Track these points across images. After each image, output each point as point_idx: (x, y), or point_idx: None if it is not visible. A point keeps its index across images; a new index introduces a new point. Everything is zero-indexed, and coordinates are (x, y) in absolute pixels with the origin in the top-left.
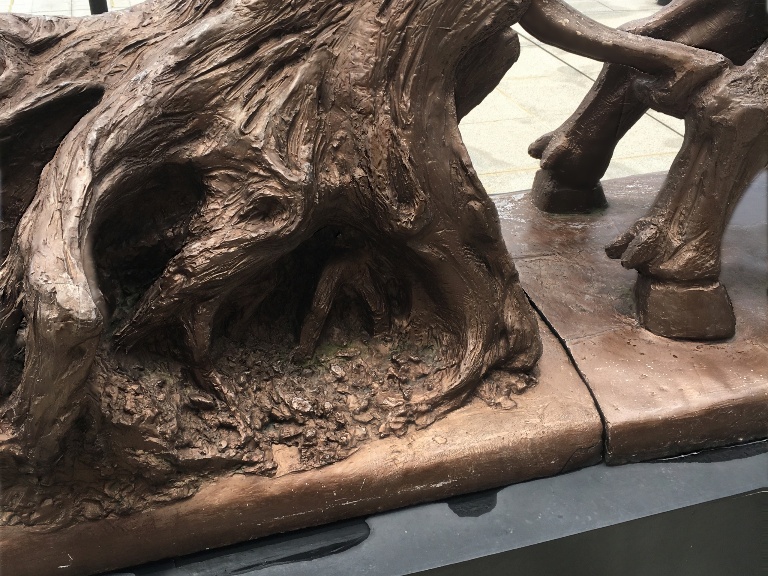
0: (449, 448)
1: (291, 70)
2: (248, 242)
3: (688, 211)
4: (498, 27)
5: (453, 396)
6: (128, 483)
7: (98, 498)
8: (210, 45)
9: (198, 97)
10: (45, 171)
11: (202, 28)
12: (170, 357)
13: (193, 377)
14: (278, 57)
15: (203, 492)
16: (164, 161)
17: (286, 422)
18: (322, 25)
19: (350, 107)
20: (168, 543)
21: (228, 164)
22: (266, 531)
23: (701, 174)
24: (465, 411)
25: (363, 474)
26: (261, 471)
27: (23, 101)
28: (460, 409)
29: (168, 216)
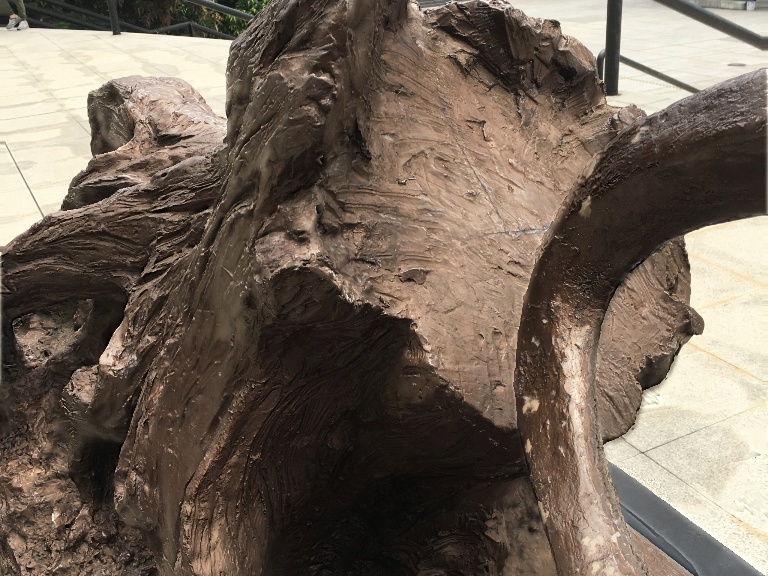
0: None
1: None
2: None
3: None
4: None
5: None
6: None
7: None
8: (175, 185)
9: (146, 233)
10: None
11: (178, 164)
12: None
13: None
14: (197, 225)
15: None
16: (108, 279)
17: None
18: None
19: None
20: None
21: None
22: None
23: None
24: None
25: None
26: None
27: None
28: None
29: None
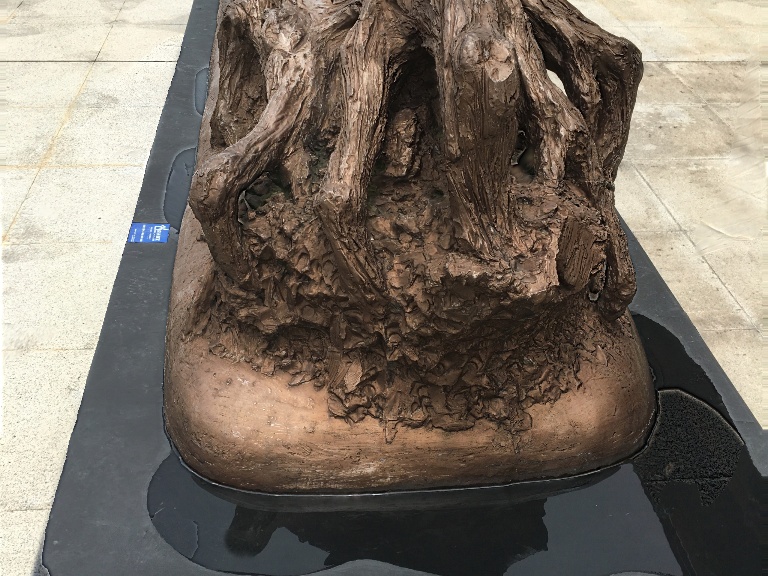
0: None
1: None
2: None
3: None
4: None
5: None
6: None
7: None
8: None
9: None
10: (542, 8)
11: None
12: None
13: None
14: None
15: None
16: None
17: None
18: None
19: None
20: None
21: None
22: None
23: None
24: None
25: None
26: None
27: None
28: None
29: None
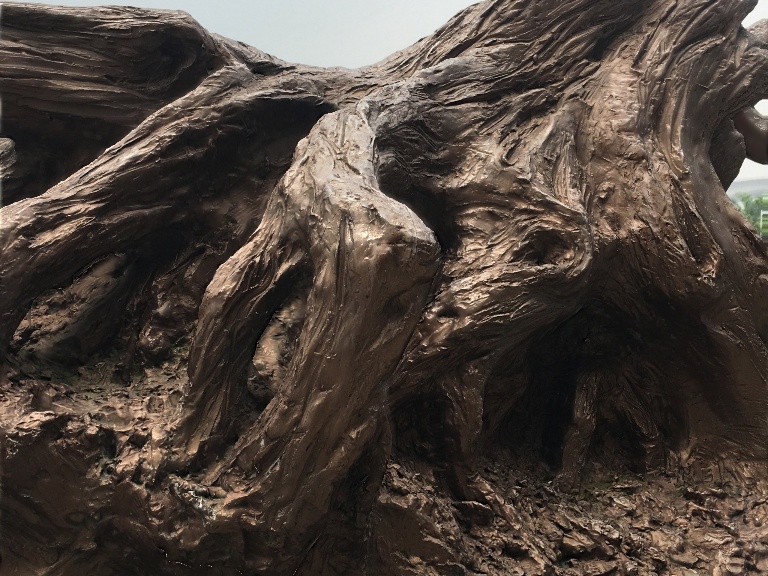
0: None
1: (541, 119)
2: (533, 277)
3: None
4: (752, 94)
5: None
6: None
7: None
8: (457, 80)
9: (450, 125)
10: (303, 142)
11: (447, 62)
12: (415, 456)
13: (451, 483)
14: (526, 104)
15: None
16: (419, 182)
17: (585, 557)
18: (569, 79)
19: (615, 155)
20: None
21: (489, 199)
22: None
23: None
24: None
25: None
26: None
27: None
28: None
29: None
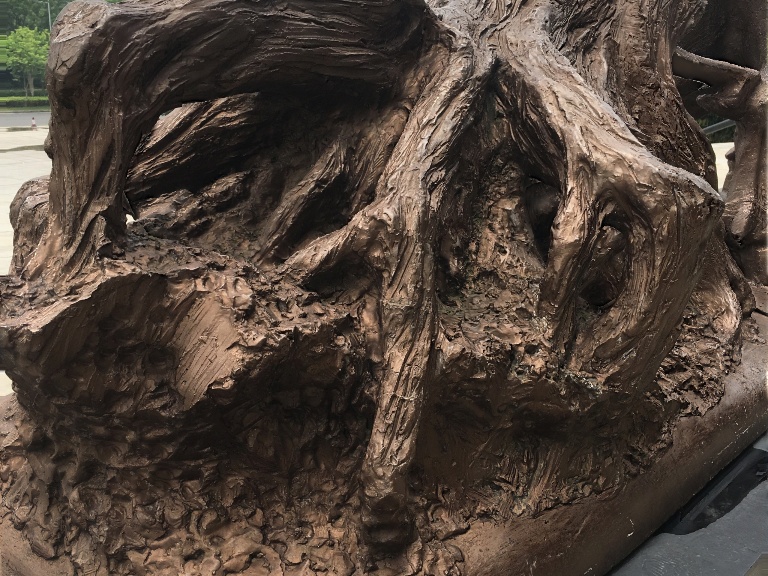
0: (765, 374)
1: (593, 56)
2: None
3: (767, 186)
4: None
5: (737, 336)
6: (641, 433)
7: (630, 452)
8: (553, 27)
9: None
10: (552, 109)
11: (546, 12)
12: None
13: None
14: None
15: (675, 437)
16: None
17: (671, 372)
18: (601, 20)
19: (640, 85)
20: (676, 493)
21: None
22: (716, 469)
23: (767, 157)
24: (746, 348)
25: (742, 403)
26: (694, 411)
27: (485, 56)
28: (742, 348)
29: (548, 186)
